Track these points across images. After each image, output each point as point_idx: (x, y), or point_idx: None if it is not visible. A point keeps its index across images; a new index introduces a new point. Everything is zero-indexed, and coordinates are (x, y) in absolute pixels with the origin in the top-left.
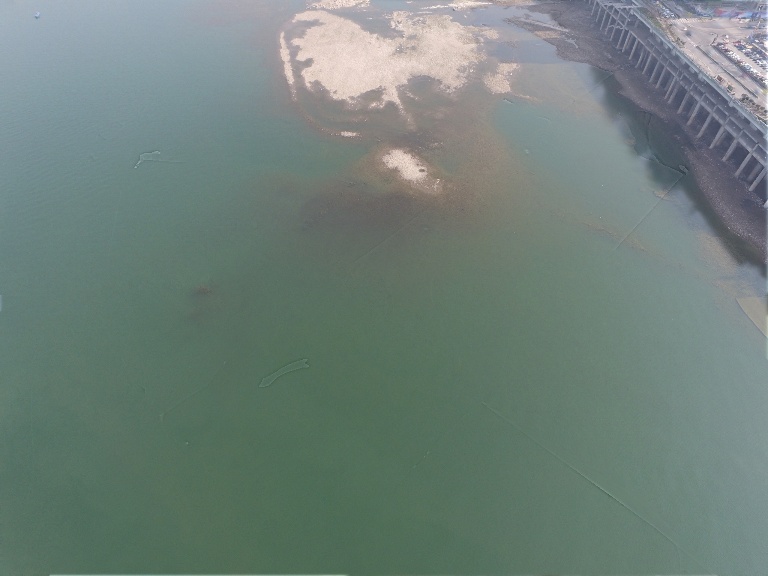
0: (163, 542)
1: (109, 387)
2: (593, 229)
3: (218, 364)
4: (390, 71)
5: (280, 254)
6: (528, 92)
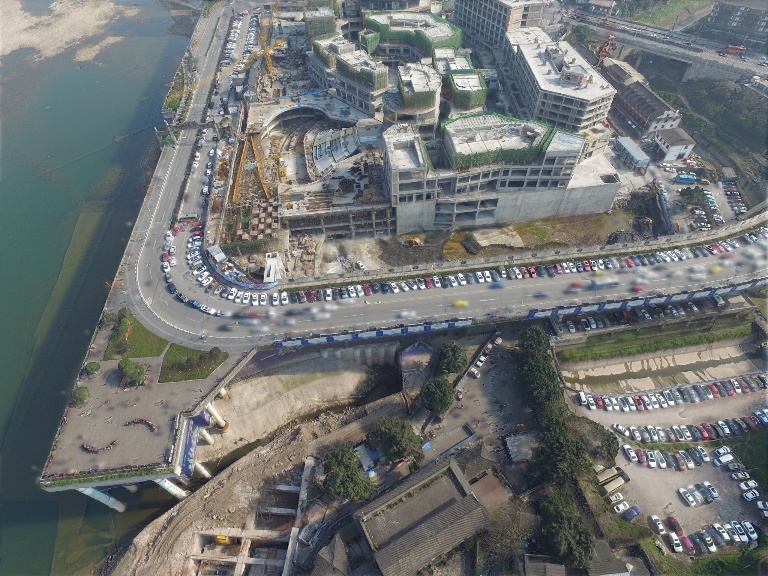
0: None
1: None
2: (29, 166)
3: None
4: (4, 44)
5: None
6: (106, 60)
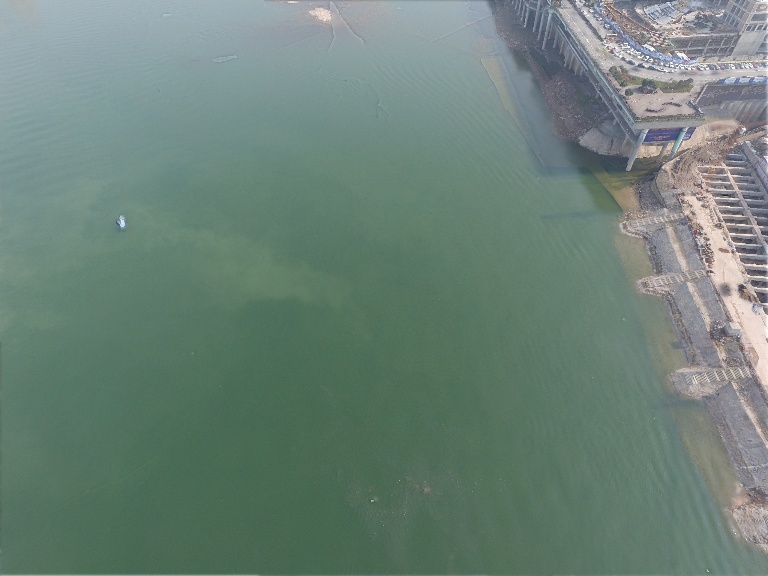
0: (165, 125)
1: (142, 82)
2: (419, 37)
3: (198, 85)
4: None
5: (238, 45)
6: None
